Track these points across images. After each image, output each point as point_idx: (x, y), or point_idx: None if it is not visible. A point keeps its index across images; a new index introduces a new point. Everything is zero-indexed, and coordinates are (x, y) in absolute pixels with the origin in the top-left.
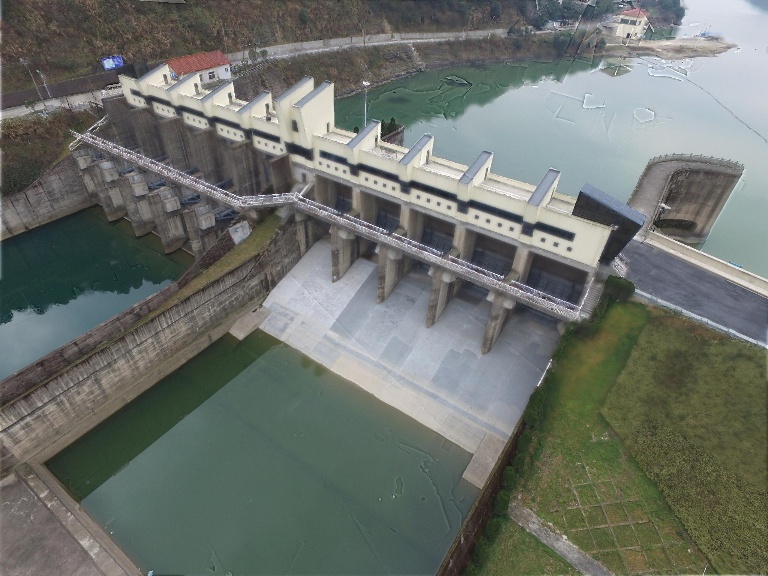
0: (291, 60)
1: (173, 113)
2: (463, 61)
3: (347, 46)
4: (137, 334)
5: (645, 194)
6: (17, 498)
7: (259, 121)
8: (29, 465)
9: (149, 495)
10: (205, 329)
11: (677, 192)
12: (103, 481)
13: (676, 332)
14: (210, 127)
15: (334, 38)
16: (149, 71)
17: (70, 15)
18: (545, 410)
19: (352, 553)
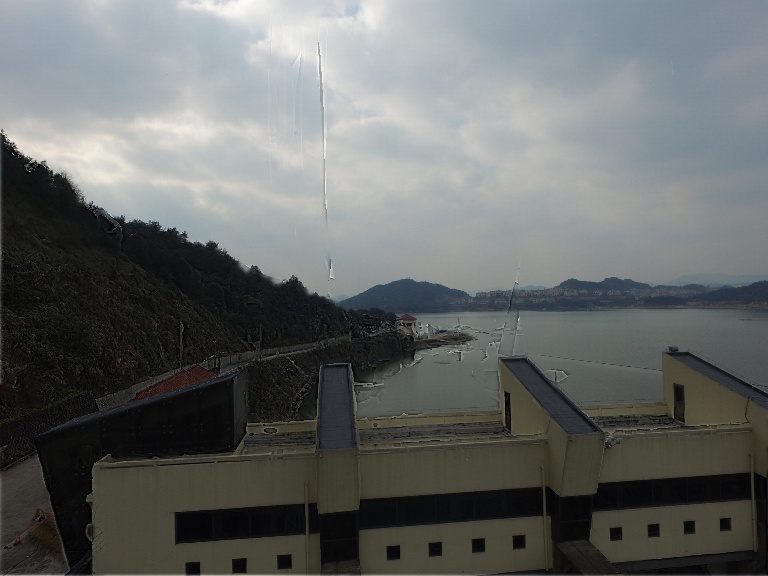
0: None
1: (511, 544)
2: None
3: None
4: None
5: None
6: None
7: None
8: None
9: None
10: None
11: None
12: None
13: None
14: None
15: None
16: None
17: None
18: None
19: None
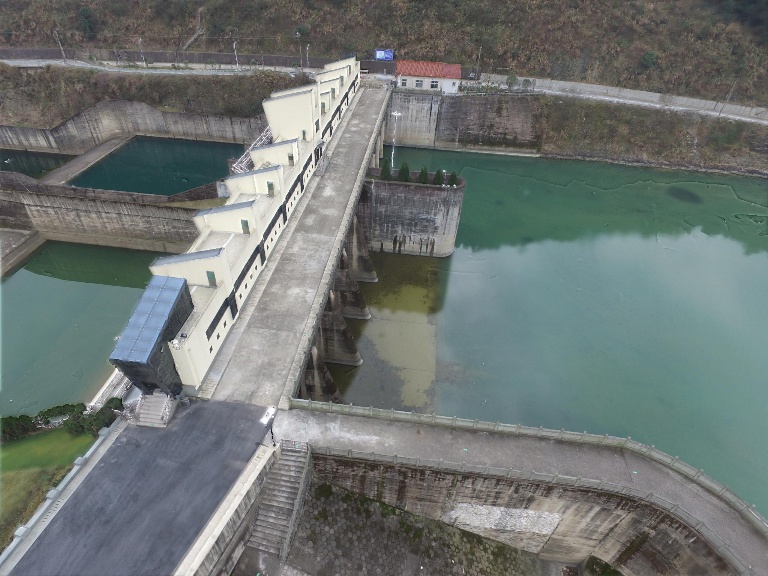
0: (567, 100)
1: None
2: None
3: None
4: (105, 204)
5: (465, 443)
6: (14, 240)
7: None
8: (38, 233)
9: (22, 284)
10: (161, 237)
11: (665, 555)
12: (86, 281)
13: (14, 502)
14: None
15: (685, 96)
16: (341, 60)
17: (376, 12)
18: (13, 443)
19: (3, 413)
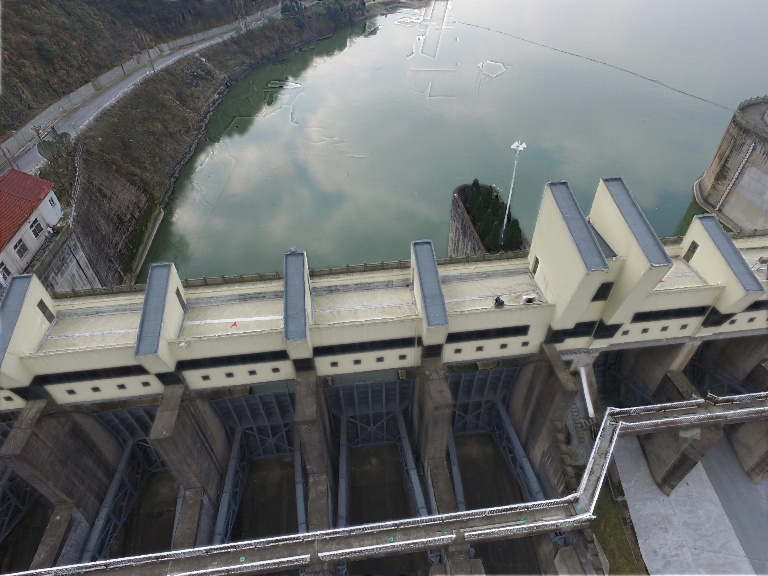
0: (96, 133)
1: (141, 385)
2: (258, 59)
3: (137, 81)
4: None
5: None
6: None
7: (474, 315)
8: None
9: None
10: None
11: None
12: None
13: None
14: (302, 374)
15: (100, 74)
16: None
17: None
18: None
19: None
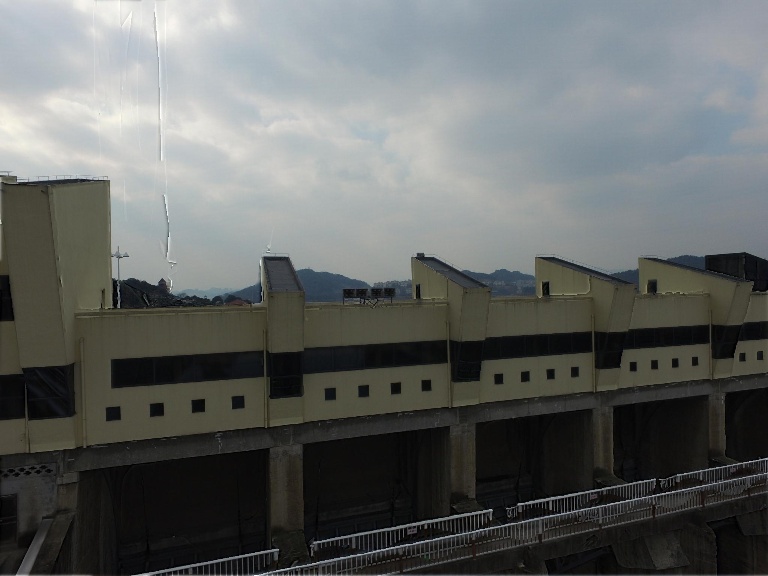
0: None
1: None
2: None
3: None
4: None
5: None
6: None
7: None
8: None
9: None
10: None
11: None
12: None
13: None
14: None
15: None
16: None
17: None
18: None
19: None
